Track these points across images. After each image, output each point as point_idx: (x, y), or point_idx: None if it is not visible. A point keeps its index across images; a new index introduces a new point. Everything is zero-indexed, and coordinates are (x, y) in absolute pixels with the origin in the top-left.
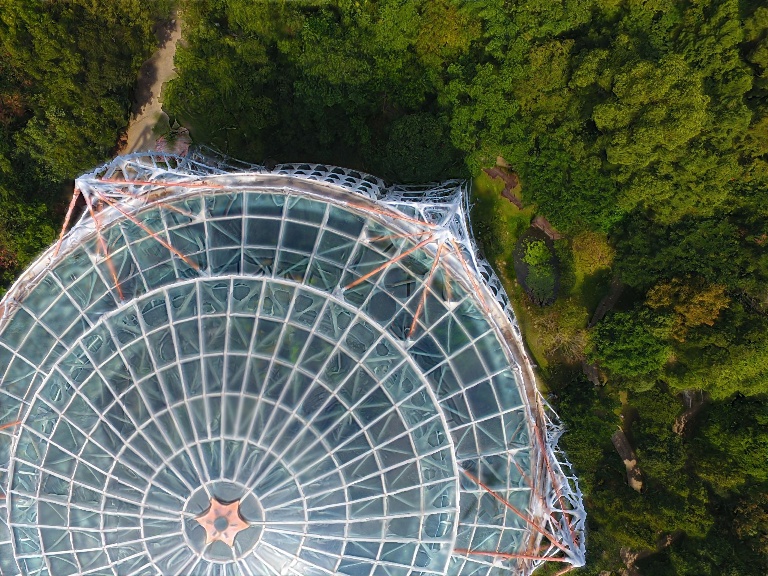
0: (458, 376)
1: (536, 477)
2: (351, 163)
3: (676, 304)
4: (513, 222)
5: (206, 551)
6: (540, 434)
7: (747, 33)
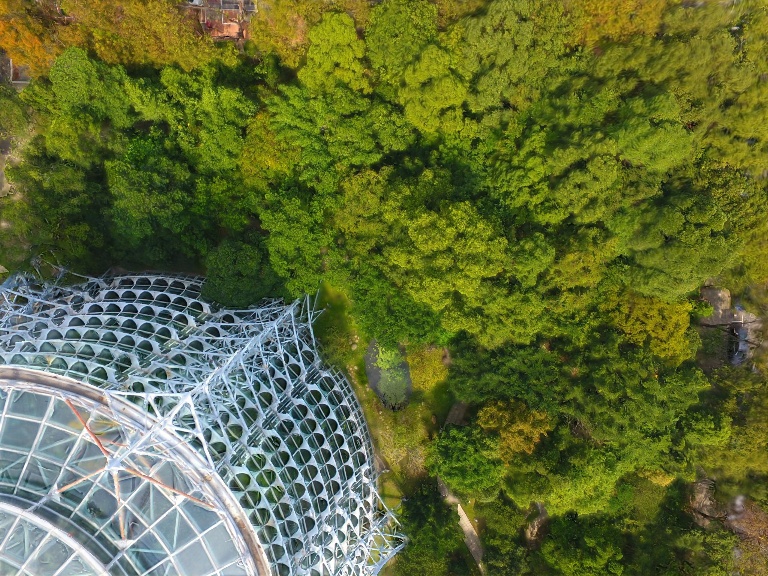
0: (184, 571)
1: None
2: (198, 270)
3: (501, 428)
4: None
5: None
6: None
7: (552, 168)
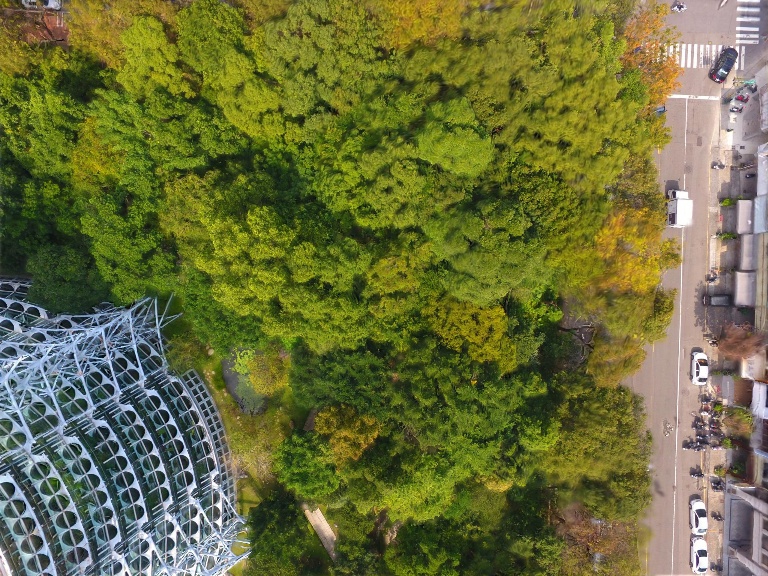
0: None
1: None
2: None
3: None
4: None
5: None
6: None
7: (366, 173)
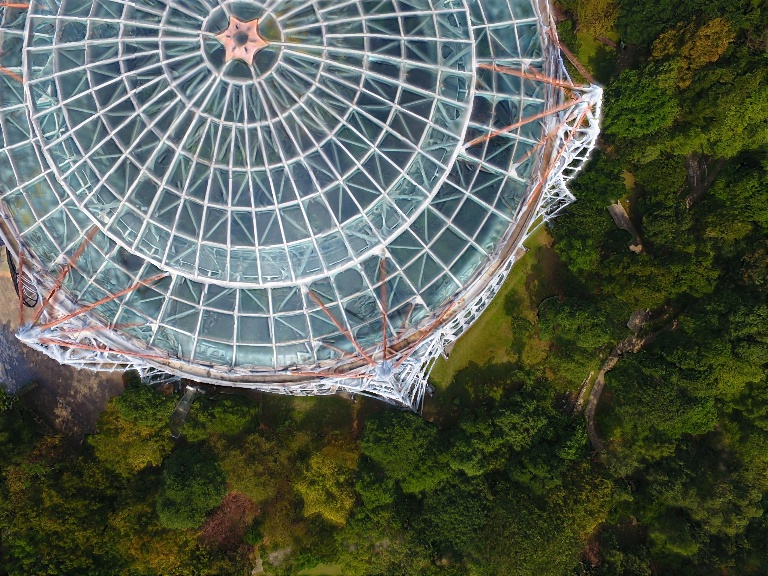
0: None
1: (550, 89)
2: None
3: (681, 47)
4: None
5: (225, 72)
6: (553, 52)
7: None
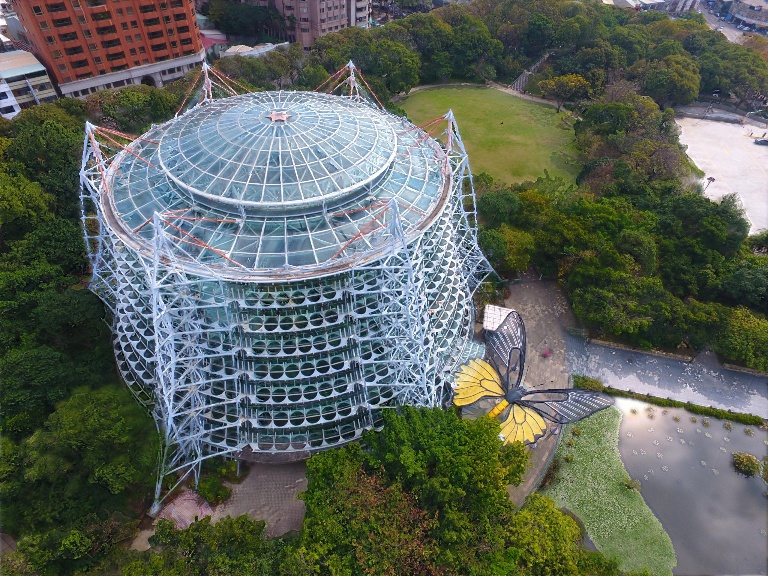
0: None
1: None
2: (114, 380)
3: None
4: None
5: None
6: None
7: None
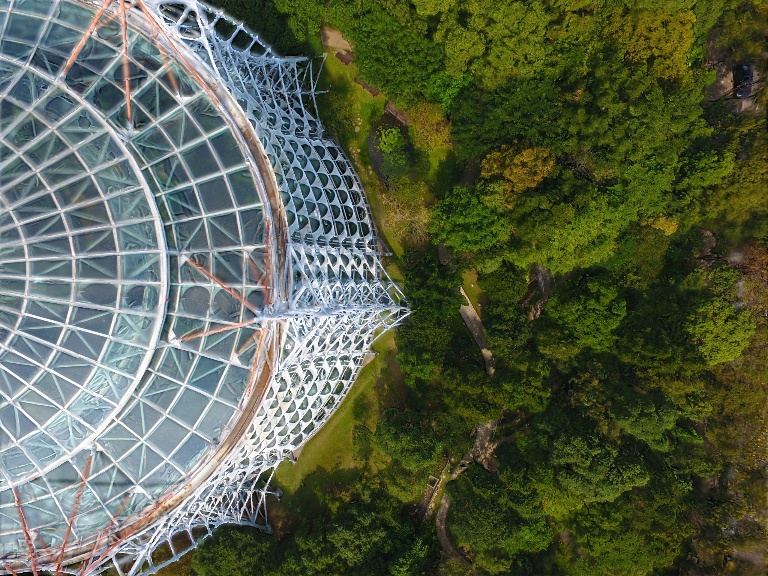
0: (191, 171)
1: (274, 275)
2: None
3: (504, 170)
4: (367, 109)
5: None
6: (282, 235)
7: None
